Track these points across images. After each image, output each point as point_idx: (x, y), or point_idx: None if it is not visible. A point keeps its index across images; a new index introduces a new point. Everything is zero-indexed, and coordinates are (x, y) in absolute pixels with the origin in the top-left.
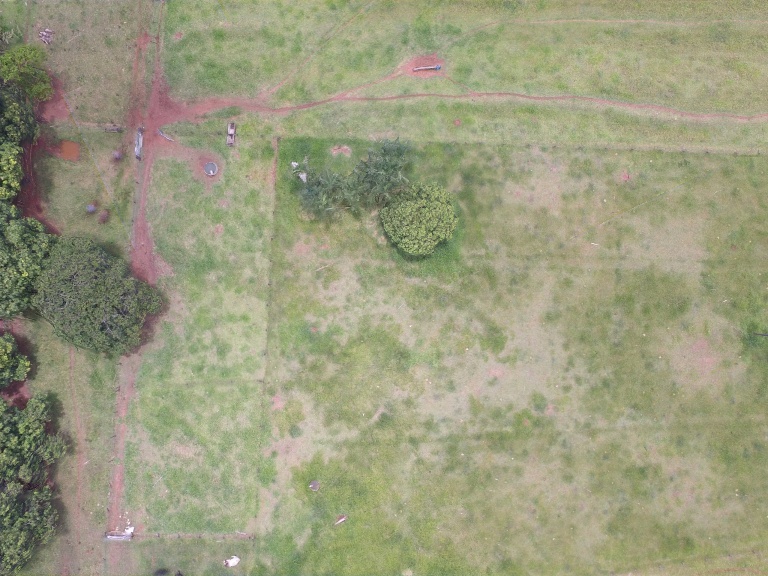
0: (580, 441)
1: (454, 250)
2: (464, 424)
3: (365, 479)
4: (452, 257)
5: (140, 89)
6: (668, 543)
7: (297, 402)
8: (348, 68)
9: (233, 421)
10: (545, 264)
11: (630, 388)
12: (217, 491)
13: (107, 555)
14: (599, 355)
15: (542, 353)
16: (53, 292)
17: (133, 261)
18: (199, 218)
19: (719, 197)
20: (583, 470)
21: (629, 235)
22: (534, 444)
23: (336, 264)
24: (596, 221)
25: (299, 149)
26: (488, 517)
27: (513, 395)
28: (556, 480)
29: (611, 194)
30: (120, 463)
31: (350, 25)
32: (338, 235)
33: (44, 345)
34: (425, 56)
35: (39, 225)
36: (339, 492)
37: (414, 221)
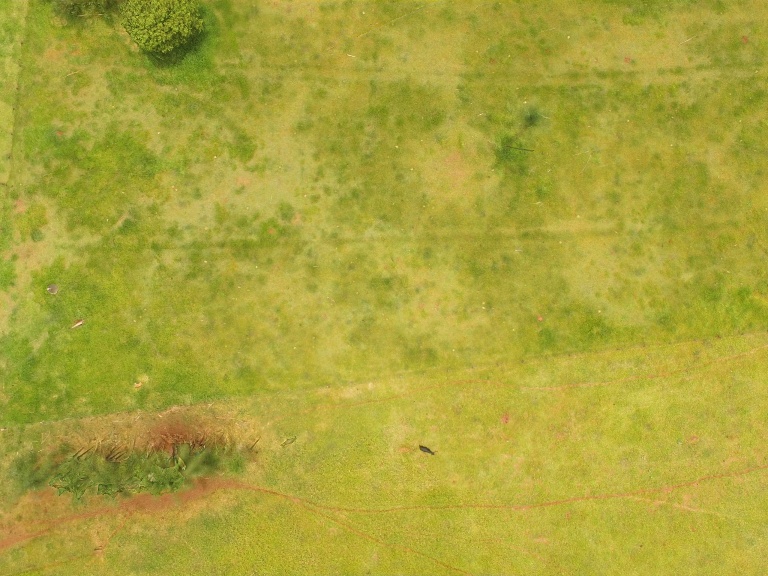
0: (326, 251)
1: (206, 57)
2: (208, 231)
3: (105, 284)
4: (203, 65)
5: None
6: (410, 354)
7: (40, 206)
8: None
9: None
10: (299, 74)
11: (379, 199)
12: None
13: None
14: (350, 166)
15: (292, 163)
16: None
17: None
18: None
19: (480, 11)
20: (328, 280)
21: (386, 47)
22: (279, 253)
23: (87, 70)
24: (354, 33)
25: None
26: (228, 324)
27: (260, 204)
28: (300, 289)
29: (370, 6)
30: None
31: None
32: (90, 41)
33: None
34: None
35: None
36: (77, 296)
37: (144, 11)
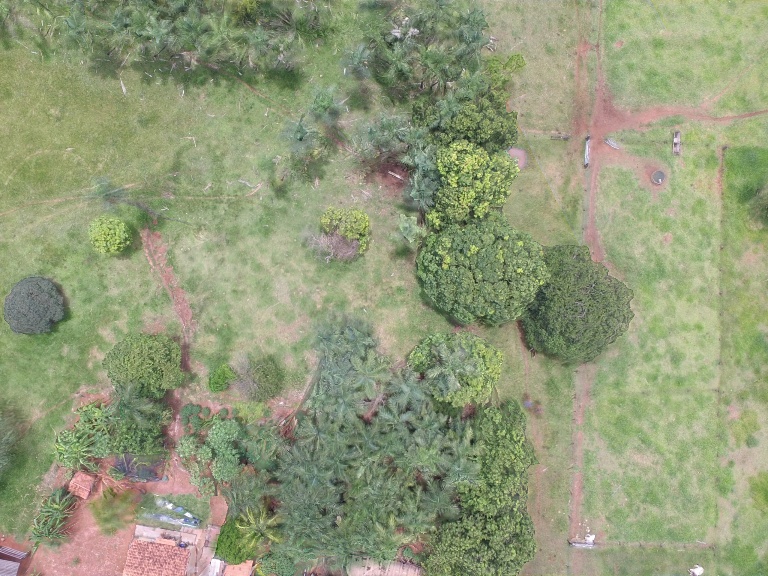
0: None
1: None
2: None
3: None
4: None
5: (584, 97)
6: None
7: (752, 412)
8: None
9: (689, 430)
10: None
11: None
12: (675, 500)
13: (570, 562)
14: None
15: None
16: (572, 300)
17: None
18: (647, 226)
19: None
20: None
21: None
22: None
23: None
24: None
25: (746, 158)
26: None
27: None
28: None
29: None
30: (579, 471)
31: None
32: None
33: None
34: None
35: None
36: None
37: None
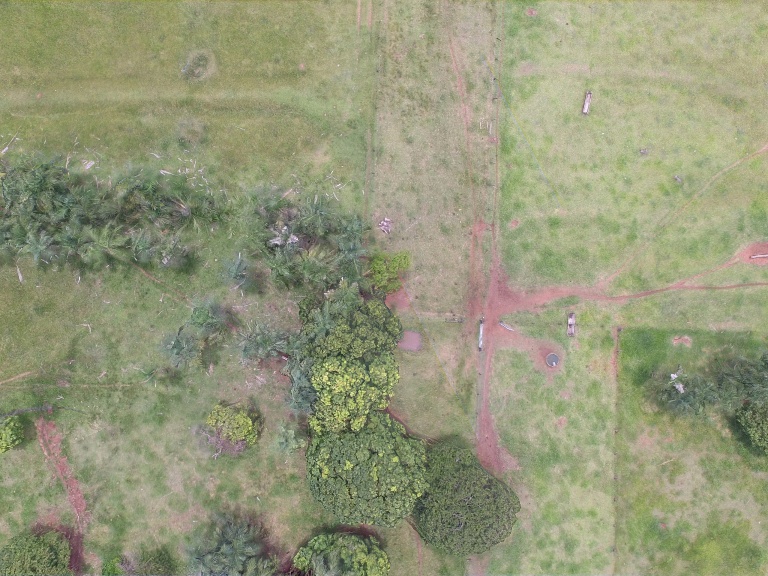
0: None
1: None
2: None
3: None
4: None
5: (478, 278)
6: None
7: None
8: (684, 255)
9: None
10: None
11: None
12: None
13: None
14: None
15: None
16: (449, 514)
17: (478, 454)
18: (542, 410)
19: None
20: None
21: None
22: None
23: (681, 457)
24: None
25: (640, 340)
26: None
27: None
28: None
29: None
30: None
31: (685, 211)
32: (682, 428)
33: (393, 540)
34: (761, 243)
35: (402, 427)
36: None
37: None
